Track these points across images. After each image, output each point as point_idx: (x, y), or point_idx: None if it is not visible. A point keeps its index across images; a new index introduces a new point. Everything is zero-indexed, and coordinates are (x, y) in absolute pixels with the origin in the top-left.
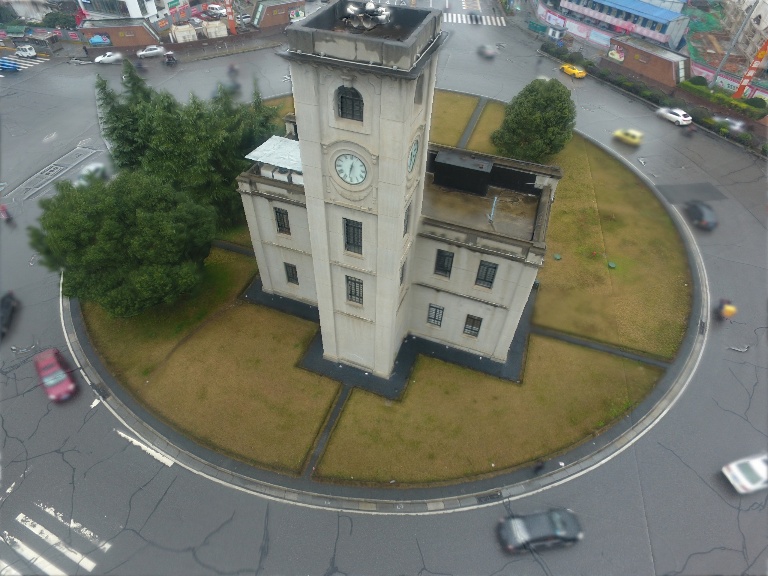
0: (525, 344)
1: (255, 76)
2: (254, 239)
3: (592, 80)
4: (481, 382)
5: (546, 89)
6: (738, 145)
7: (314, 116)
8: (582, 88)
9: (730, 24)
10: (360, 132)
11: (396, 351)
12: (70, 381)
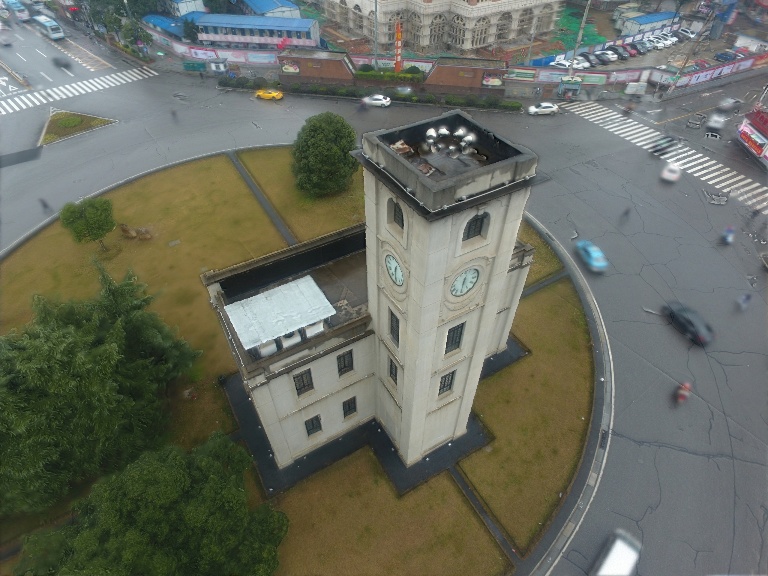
0: None
1: None
2: (269, 425)
3: (290, 97)
4: (513, 374)
5: (326, 123)
6: (429, 105)
7: (444, 257)
8: (292, 107)
9: (332, 16)
10: (483, 246)
11: None
12: None
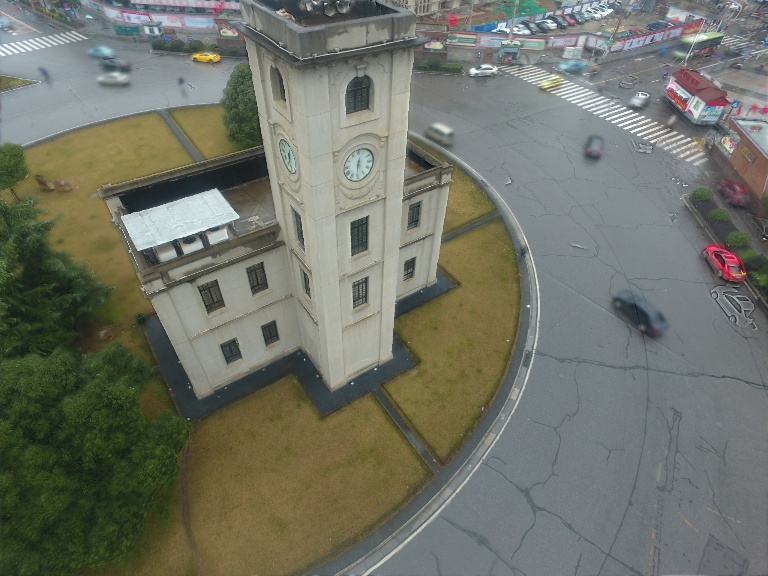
0: None
1: None
2: (178, 344)
3: (229, 60)
4: (441, 304)
5: None
6: None
7: (327, 124)
8: (230, 69)
9: None
10: (371, 120)
11: None
12: None
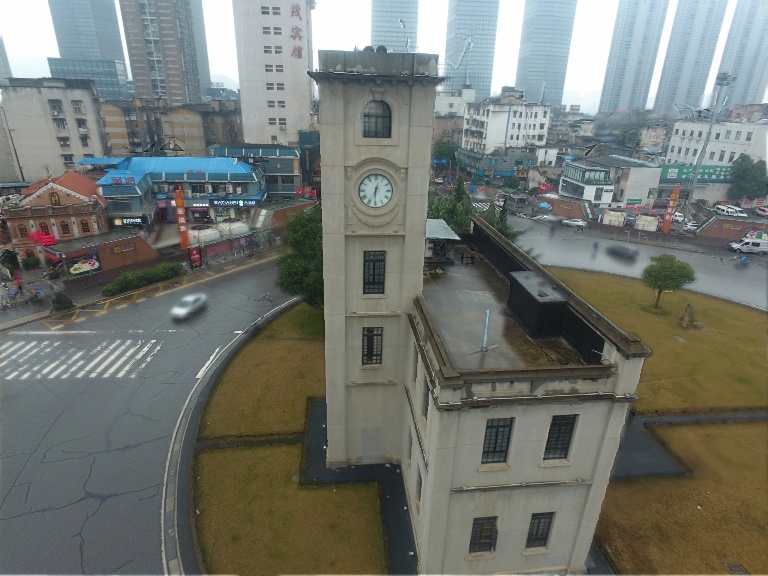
0: None
1: (634, 260)
2: None
3: None
4: (369, 564)
5: None
6: None
7: None
8: None
9: None
10: None
11: (364, 457)
12: (252, 318)
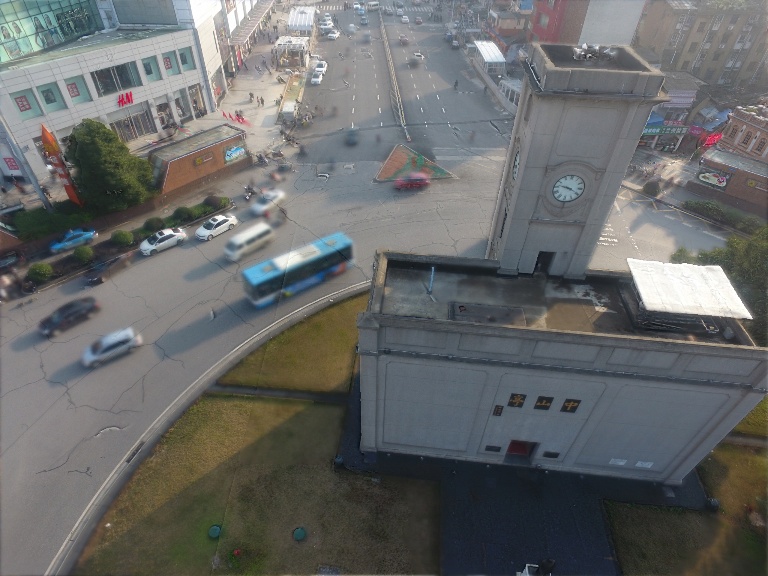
0: (354, 381)
1: None
2: None
3: None
4: None
5: None
6: None
7: None
8: None
9: None
10: None
11: None
12: None
